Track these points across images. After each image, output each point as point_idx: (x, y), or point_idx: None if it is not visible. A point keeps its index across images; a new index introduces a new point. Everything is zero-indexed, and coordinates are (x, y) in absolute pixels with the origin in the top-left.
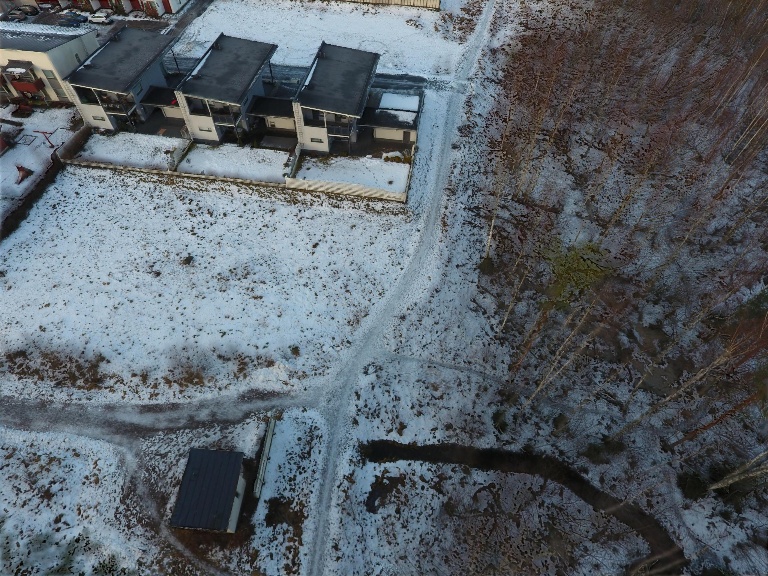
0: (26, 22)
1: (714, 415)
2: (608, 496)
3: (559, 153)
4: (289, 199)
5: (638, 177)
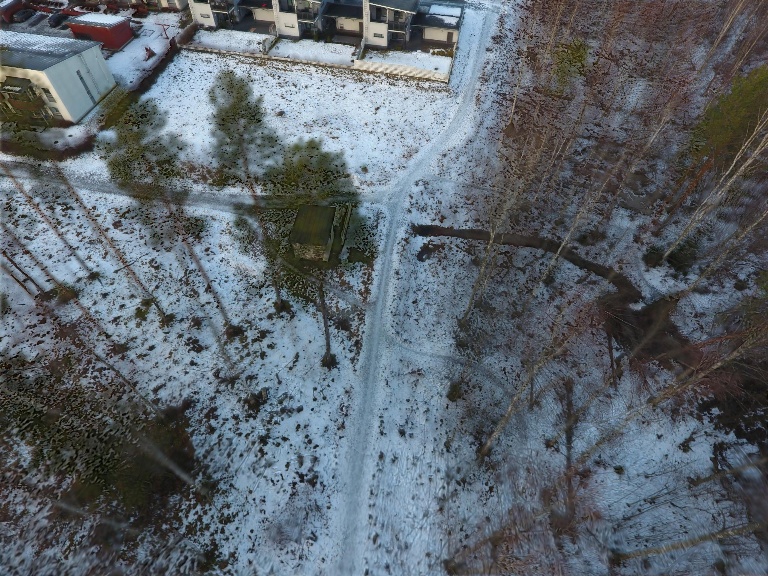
0: None
1: (676, 224)
2: (591, 263)
3: (575, 61)
4: (356, 78)
5: (639, 79)
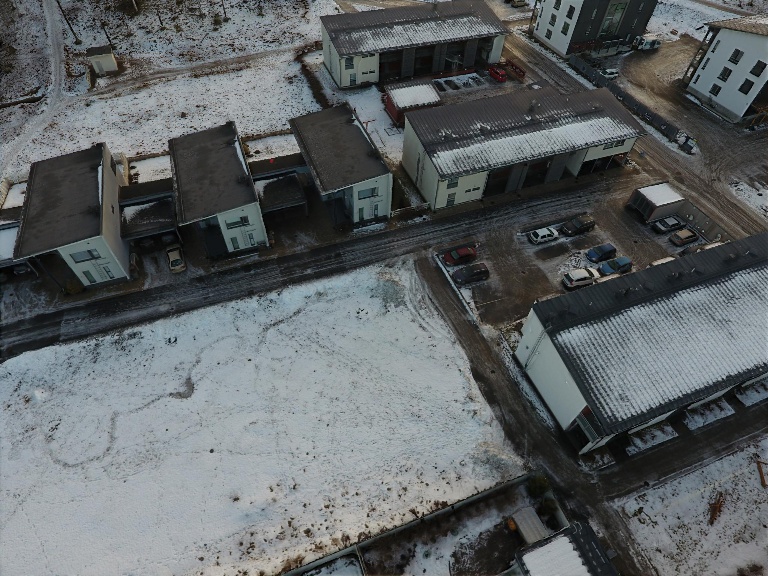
0: (662, 239)
1: None
2: None
3: None
4: None
5: None
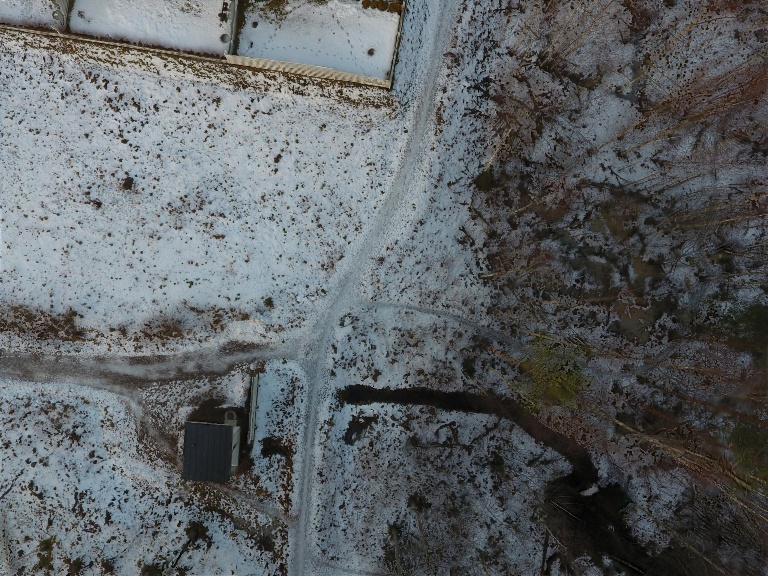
0: None
1: (674, 360)
2: (551, 431)
3: None
4: (235, 81)
5: (723, 15)
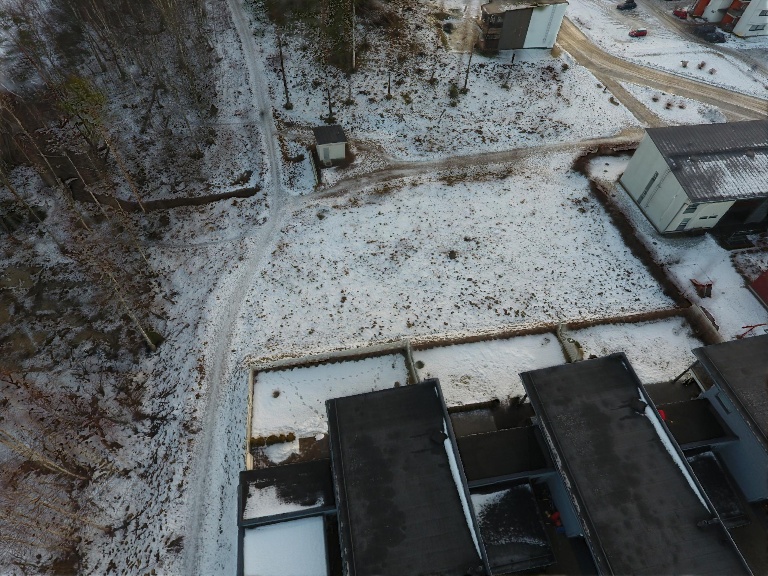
0: None
1: None
2: None
3: None
4: None
5: None
